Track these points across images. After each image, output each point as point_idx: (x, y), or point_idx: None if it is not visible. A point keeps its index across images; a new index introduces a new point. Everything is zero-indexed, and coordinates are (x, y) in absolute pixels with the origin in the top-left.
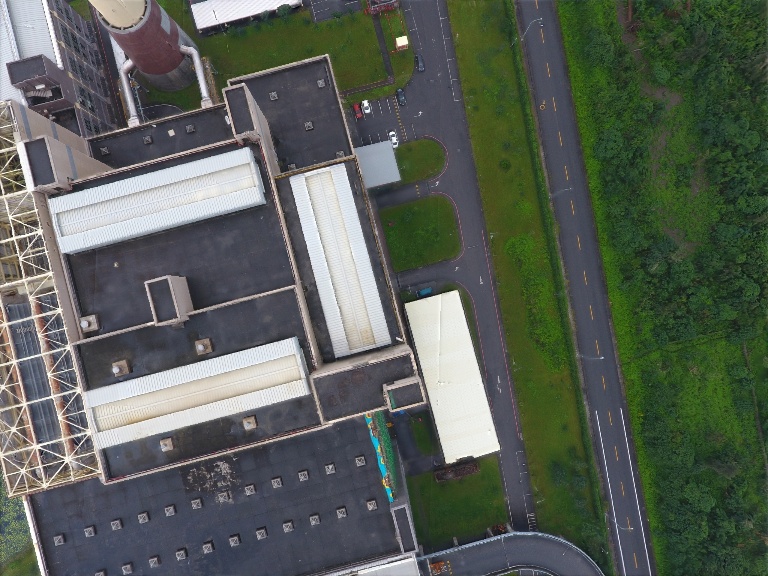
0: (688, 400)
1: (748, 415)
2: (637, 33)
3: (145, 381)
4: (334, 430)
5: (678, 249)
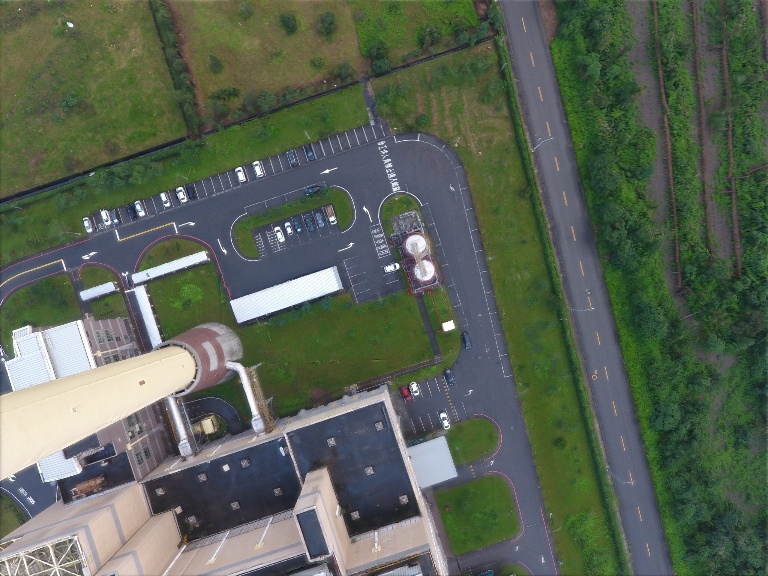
0: None
1: None
2: (687, 297)
3: None
4: None
5: (741, 514)
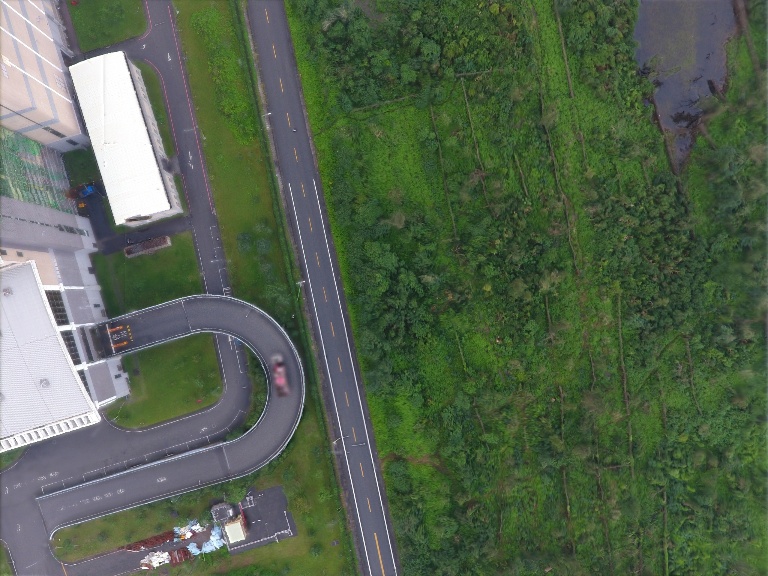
0: (378, 167)
1: (437, 178)
2: None
3: None
4: None
5: (367, 19)
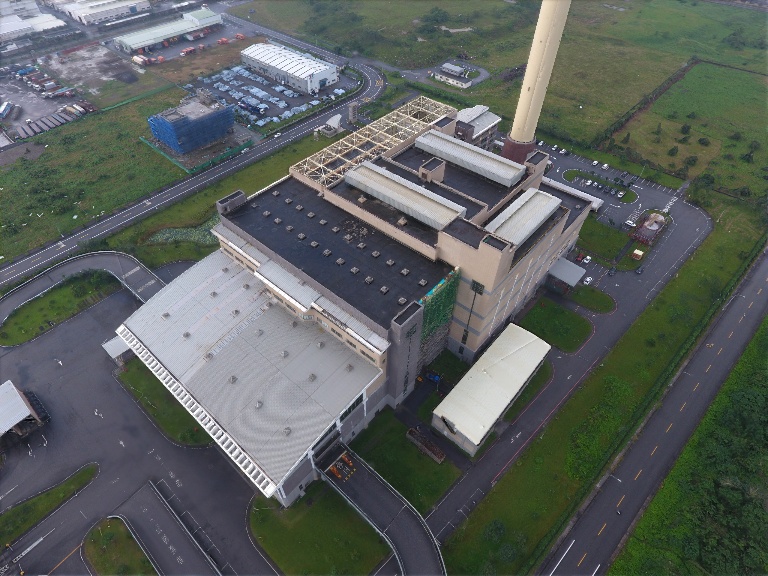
0: None
1: None
2: None
3: (391, 174)
4: (428, 264)
5: None
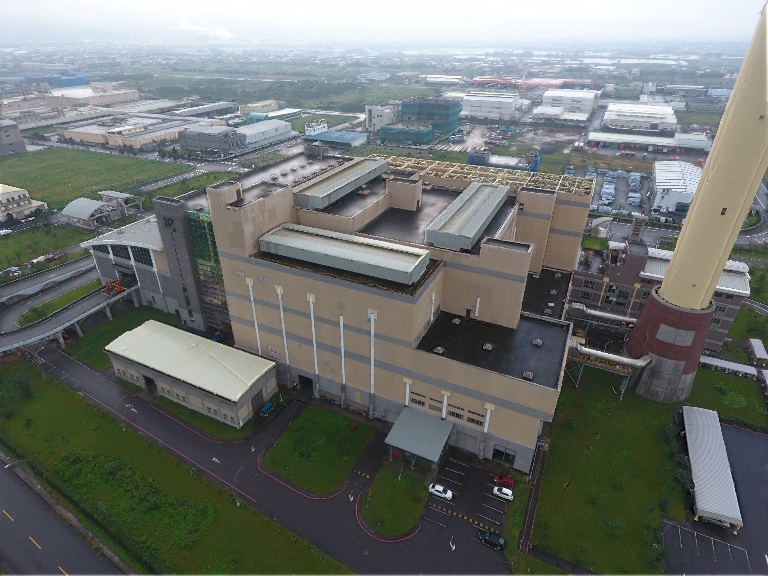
0: None
1: None
2: None
3: None
4: None
5: None
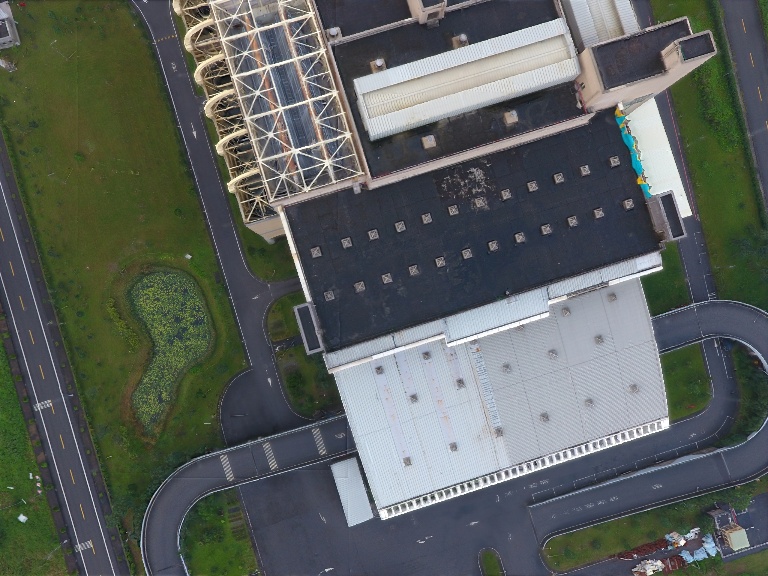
0: None
1: None
2: None
3: (415, 66)
4: (586, 133)
5: None
